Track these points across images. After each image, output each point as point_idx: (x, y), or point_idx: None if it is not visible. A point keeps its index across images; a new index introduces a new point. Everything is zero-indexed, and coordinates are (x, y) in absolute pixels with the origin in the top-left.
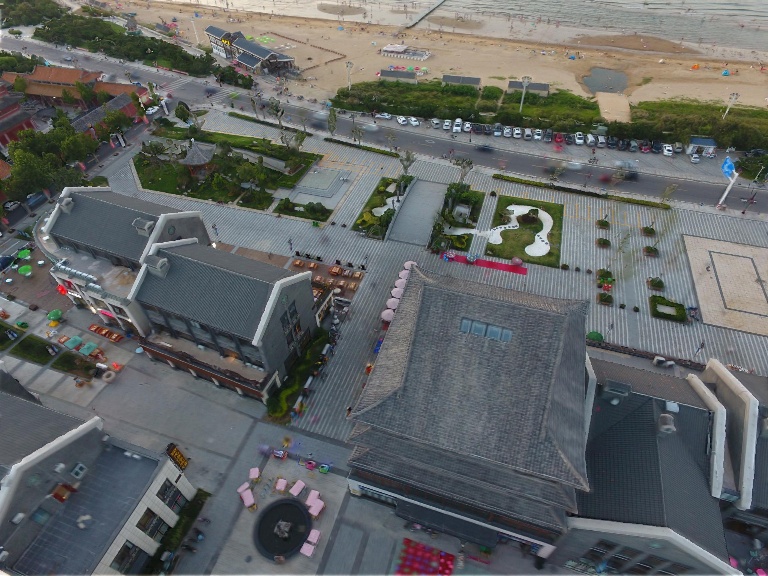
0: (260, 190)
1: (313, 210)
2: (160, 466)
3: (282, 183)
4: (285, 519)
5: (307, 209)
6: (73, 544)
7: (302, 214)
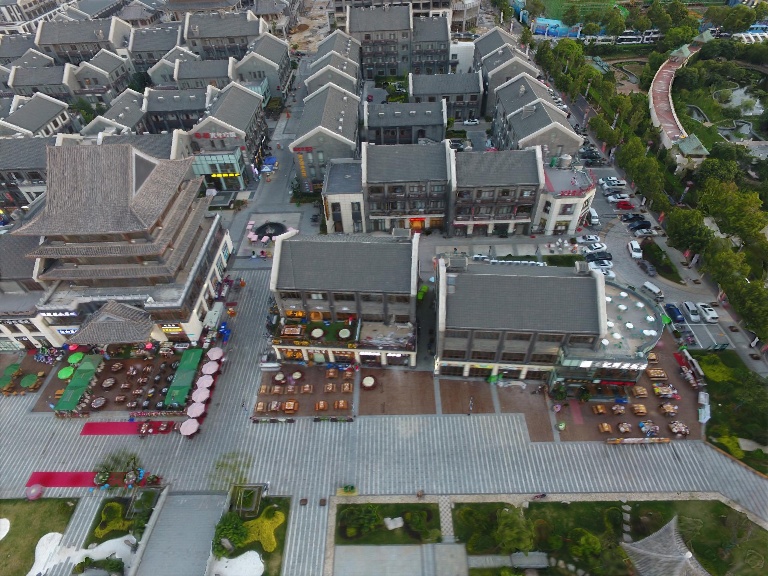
0: (486, 537)
1: None
2: (323, 191)
3: None
4: (270, 235)
5: (371, 505)
6: (346, 172)
7: (385, 512)
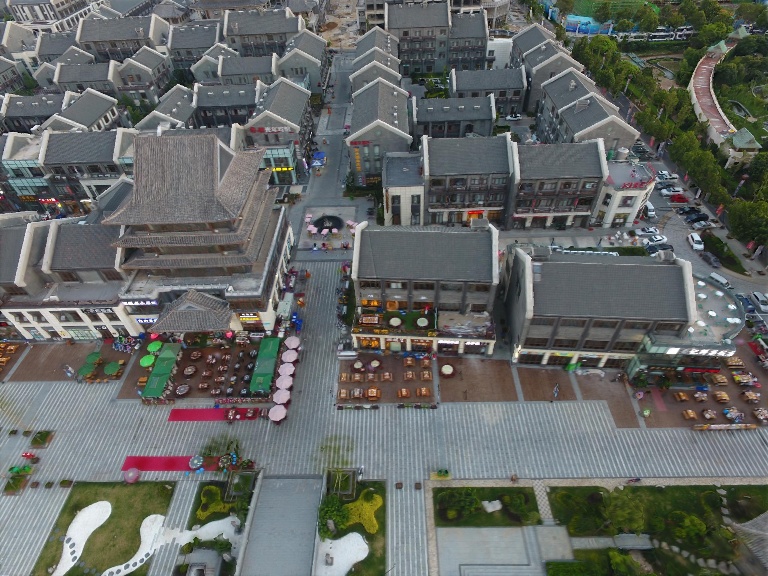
0: (588, 519)
1: (460, 493)
2: (384, 183)
3: (576, 572)
4: (328, 227)
5: (470, 488)
6: None
7: (481, 495)
